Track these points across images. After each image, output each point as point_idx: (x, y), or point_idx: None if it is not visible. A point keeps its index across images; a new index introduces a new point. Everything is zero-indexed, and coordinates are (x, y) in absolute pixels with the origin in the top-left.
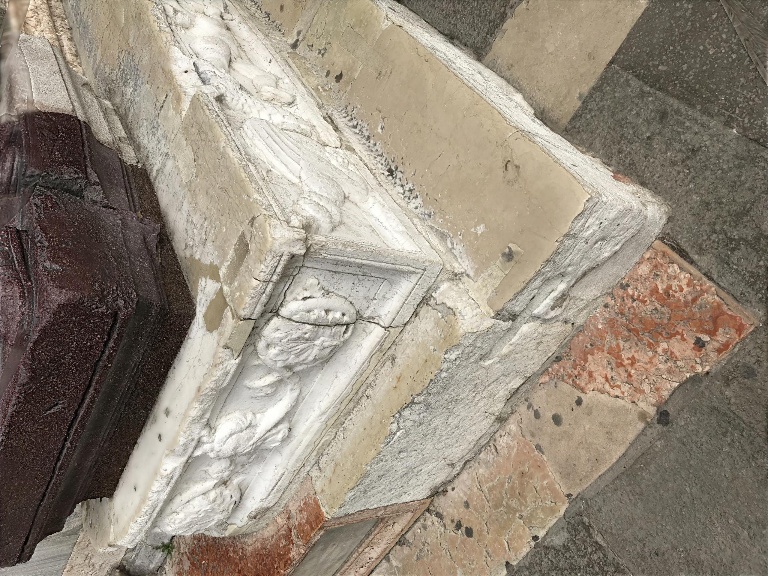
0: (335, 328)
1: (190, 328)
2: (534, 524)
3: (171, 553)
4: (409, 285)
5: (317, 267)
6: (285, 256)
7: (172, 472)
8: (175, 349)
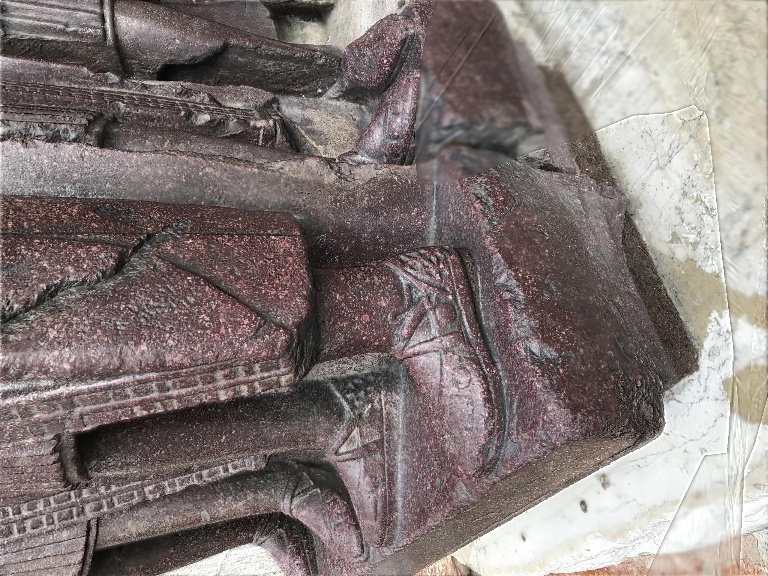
0: None
1: (678, 384)
2: None
3: None
4: None
5: None
6: None
7: (597, 554)
8: None
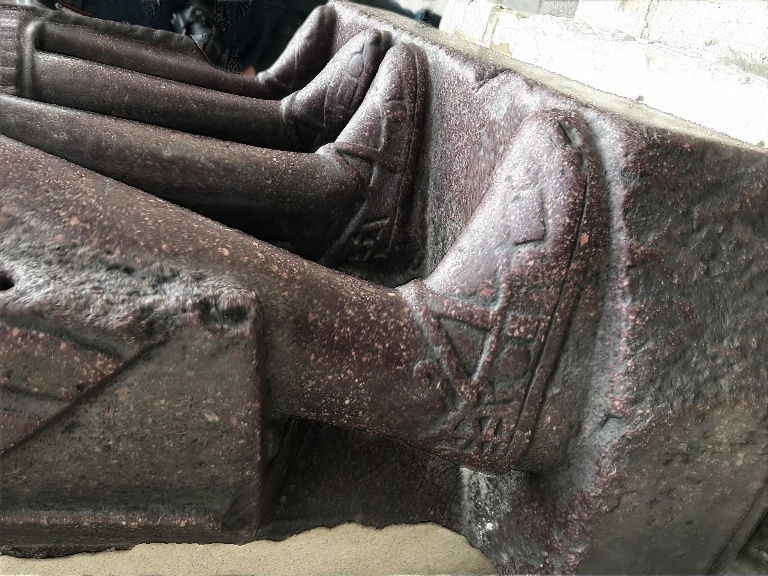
0: None
1: None
2: None
3: None
4: None
5: None
6: None
7: None
8: None
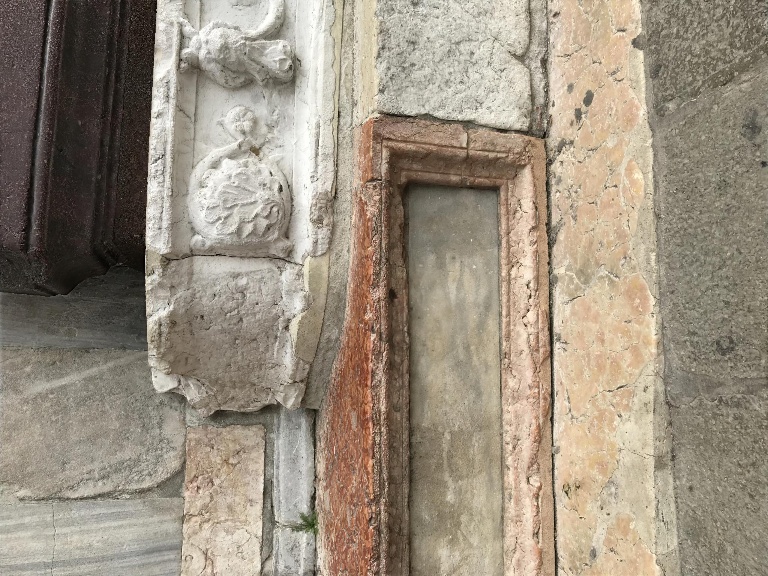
0: None
1: None
2: None
3: (317, 528)
4: None
5: None
6: None
7: (166, 78)
8: (155, 3)
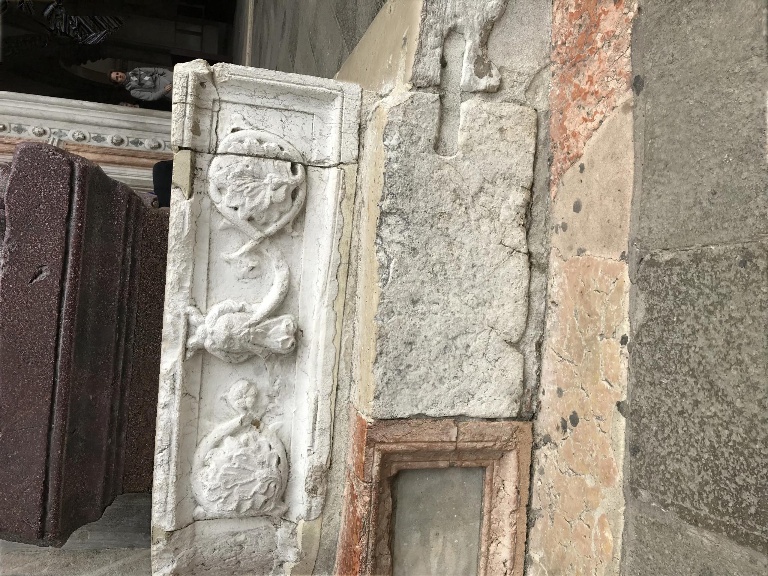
0: (277, 162)
1: None
2: (614, 326)
3: None
4: (336, 112)
5: (235, 101)
6: (191, 76)
7: (172, 370)
8: (164, 258)
